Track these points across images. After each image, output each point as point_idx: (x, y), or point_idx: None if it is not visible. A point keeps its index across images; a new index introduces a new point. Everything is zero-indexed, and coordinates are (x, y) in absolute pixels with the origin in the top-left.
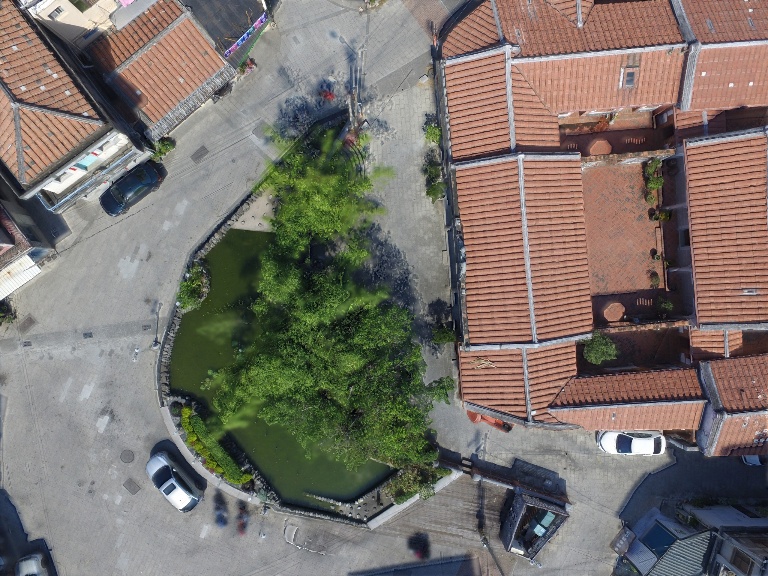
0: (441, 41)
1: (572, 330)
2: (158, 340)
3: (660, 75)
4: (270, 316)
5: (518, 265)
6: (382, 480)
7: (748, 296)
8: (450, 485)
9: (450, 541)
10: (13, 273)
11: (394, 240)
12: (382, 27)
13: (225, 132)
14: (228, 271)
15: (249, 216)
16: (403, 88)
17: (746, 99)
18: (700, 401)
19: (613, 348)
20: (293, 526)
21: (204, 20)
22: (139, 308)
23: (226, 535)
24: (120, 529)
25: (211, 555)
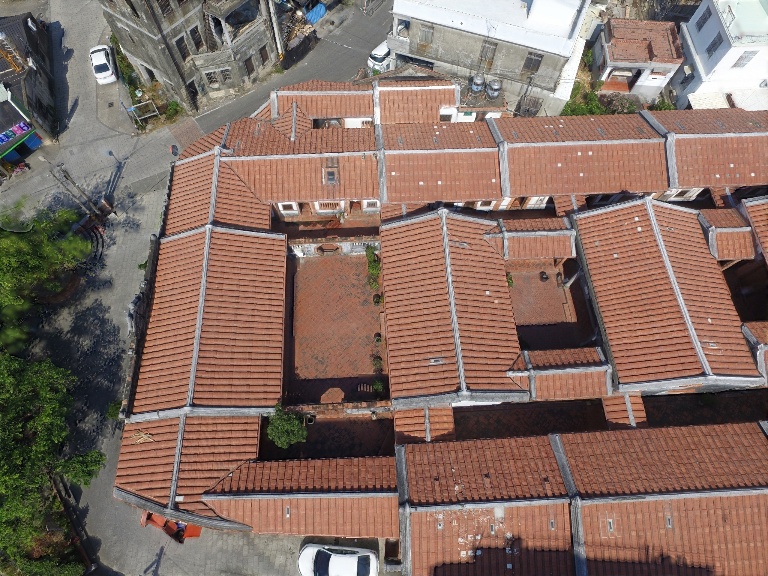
0: None
1: (248, 401)
2: None
3: (359, 175)
4: None
5: (191, 325)
6: None
7: (435, 366)
8: None
9: None
10: None
11: (112, 315)
12: (148, 146)
13: None
14: None
15: None
16: (155, 189)
17: (438, 195)
18: (390, 494)
19: (296, 425)
20: None
21: None
22: None
23: None
24: None
25: None
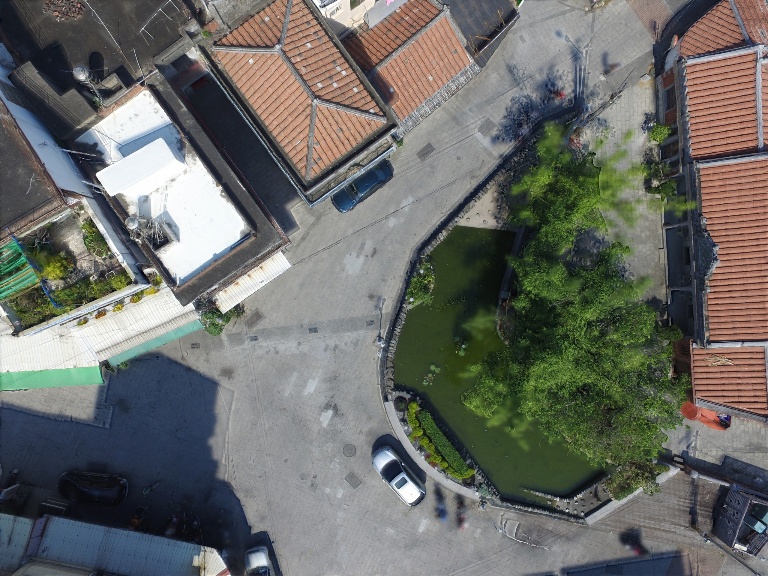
0: (663, 40)
1: None
2: (381, 335)
3: None
4: (532, 312)
5: (765, 263)
6: (598, 476)
7: None
8: (665, 481)
9: (663, 537)
10: (265, 268)
11: (611, 238)
12: (606, 26)
13: (451, 130)
14: (450, 267)
15: (474, 213)
16: None
17: None
18: None
19: None
20: (514, 521)
21: (459, 18)
22: (363, 304)
23: (444, 529)
24: (341, 522)
25: (429, 549)
